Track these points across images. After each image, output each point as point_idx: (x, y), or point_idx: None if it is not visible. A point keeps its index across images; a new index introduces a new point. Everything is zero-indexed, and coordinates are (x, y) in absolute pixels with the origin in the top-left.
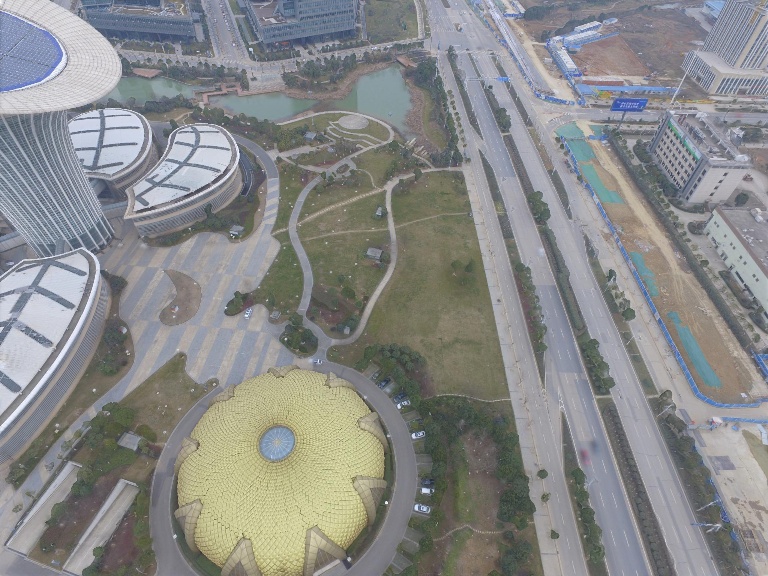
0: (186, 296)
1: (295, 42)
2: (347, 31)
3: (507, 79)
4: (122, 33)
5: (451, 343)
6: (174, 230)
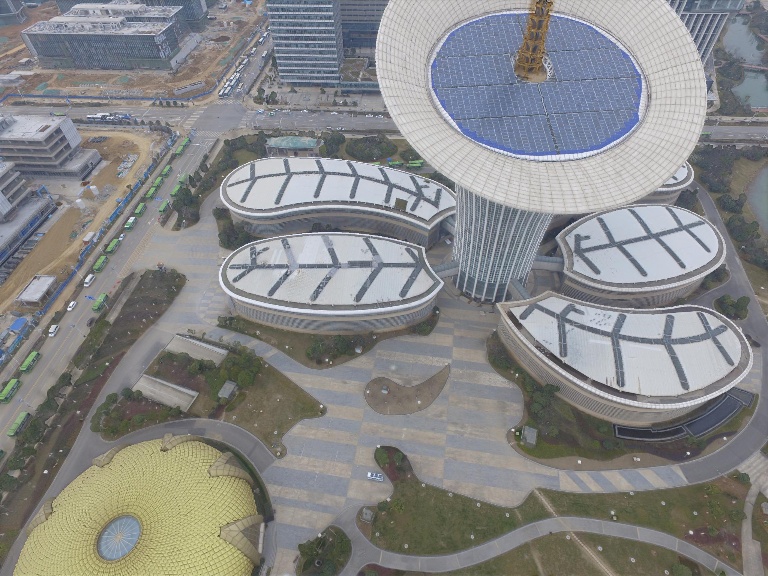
0: (407, 397)
1: None
2: None
3: None
4: None
5: None
6: (518, 358)
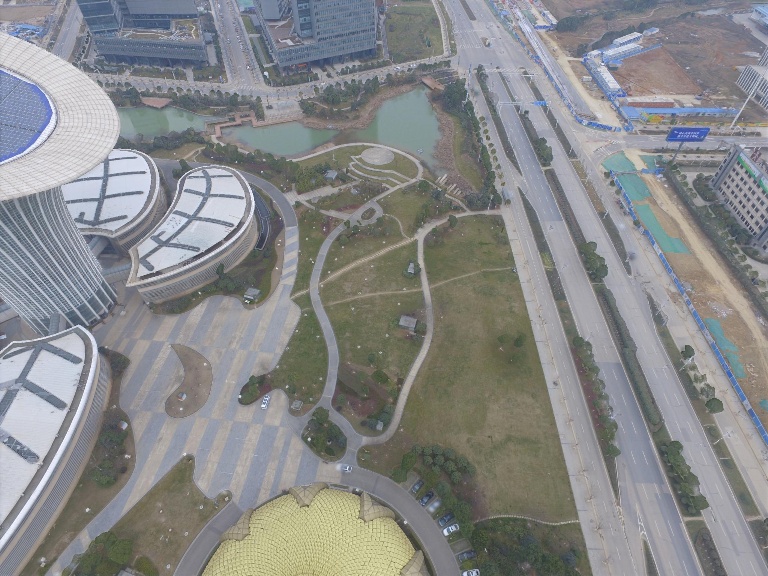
0: (195, 379)
1: (313, 64)
2: (368, 50)
3: (545, 103)
4: (131, 58)
5: (503, 442)
6: (183, 293)
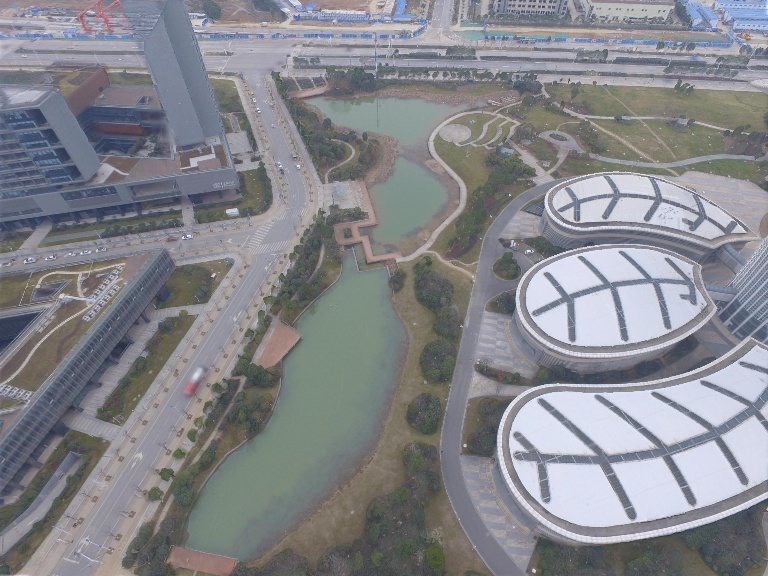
0: None
1: None
2: None
3: None
4: None
5: None
6: None
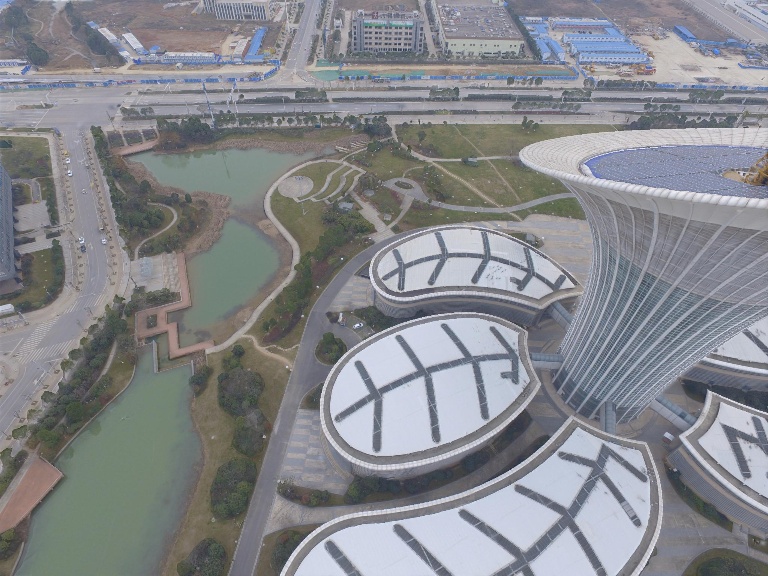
0: None
1: None
2: None
3: (235, 83)
4: None
5: None
6: None
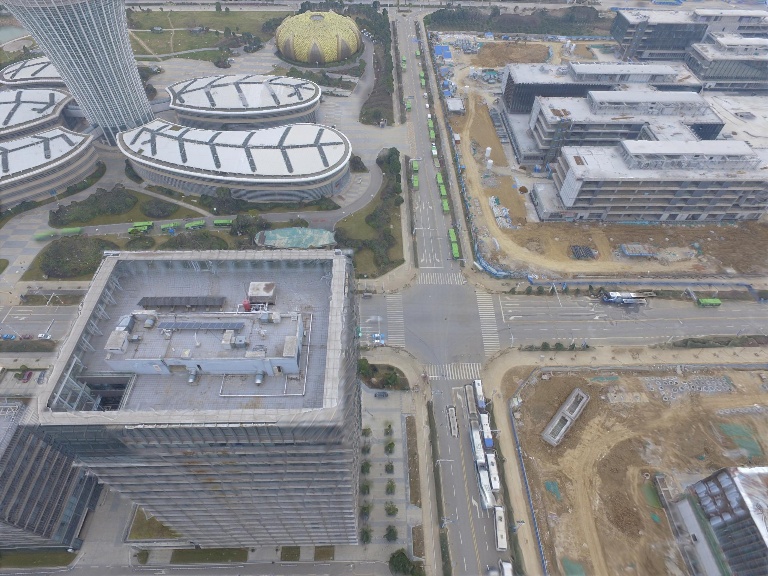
0: None
1: None
2: None
3: None
4: None
5: None
6: None
